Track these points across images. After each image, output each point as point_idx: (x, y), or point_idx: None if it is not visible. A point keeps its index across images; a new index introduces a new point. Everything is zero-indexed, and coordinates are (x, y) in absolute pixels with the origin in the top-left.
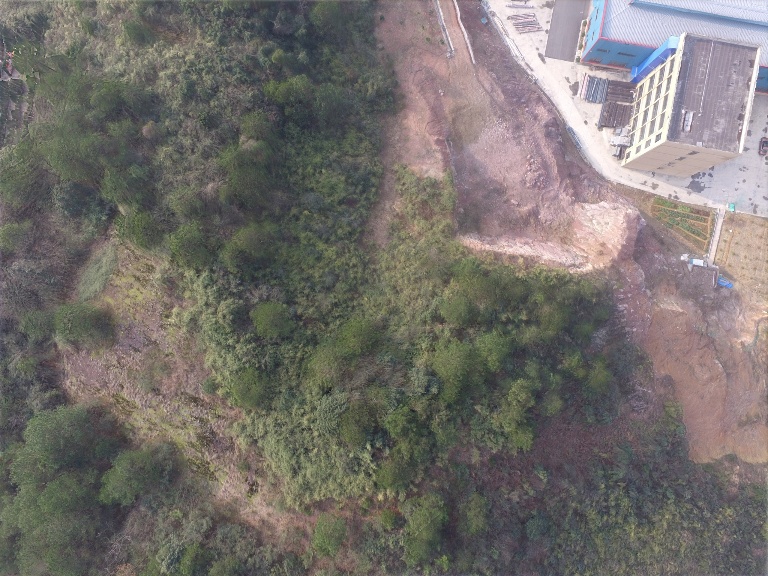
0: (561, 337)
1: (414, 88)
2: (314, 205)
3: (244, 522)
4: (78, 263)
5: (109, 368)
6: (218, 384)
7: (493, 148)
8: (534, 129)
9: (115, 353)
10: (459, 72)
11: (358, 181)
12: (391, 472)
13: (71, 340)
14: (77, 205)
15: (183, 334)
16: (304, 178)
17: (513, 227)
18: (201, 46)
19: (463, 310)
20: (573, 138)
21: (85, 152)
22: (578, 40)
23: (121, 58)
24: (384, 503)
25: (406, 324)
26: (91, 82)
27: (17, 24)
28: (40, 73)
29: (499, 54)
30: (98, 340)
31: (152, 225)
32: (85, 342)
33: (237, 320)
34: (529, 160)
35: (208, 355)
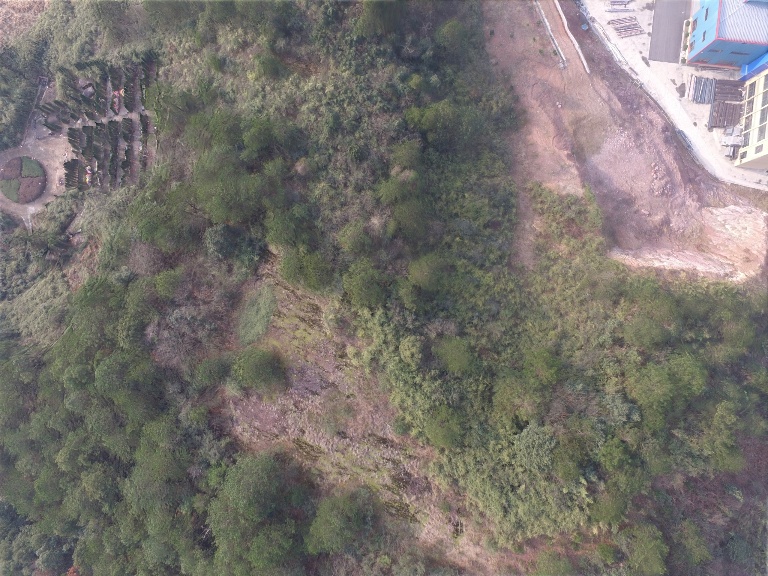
0: (740, 352)
1: (534, 102)
2: (467, 232)
3: (453, 564)
4: (233, 306)
5: (286, 413)
6: (408, 424)
7: (617, 158)
8: (653, 135)
9: (291, 397)
10: (574, 83)
11: (499, 203)
12: (605, 505)
13: (245, 387)
14: (230, 247)
15: (361, 374)
16: (447, 204)
17: (649, 238)
18: (336, 76)
19: (649, 332)
20: (684, 141)
21: (245, 195)
22: (681, 41)
23: (257, 94)
24: (599, 537)
25: (580, 348)
26: (232, 121)
27: (125, 63)
28: (170, 114)
29: (604, 60)
30: (270, 385)
31: (321, 265)
32: (258, 388)
33: (422, 358)
34: (654, 168)
35: (394, 395)
